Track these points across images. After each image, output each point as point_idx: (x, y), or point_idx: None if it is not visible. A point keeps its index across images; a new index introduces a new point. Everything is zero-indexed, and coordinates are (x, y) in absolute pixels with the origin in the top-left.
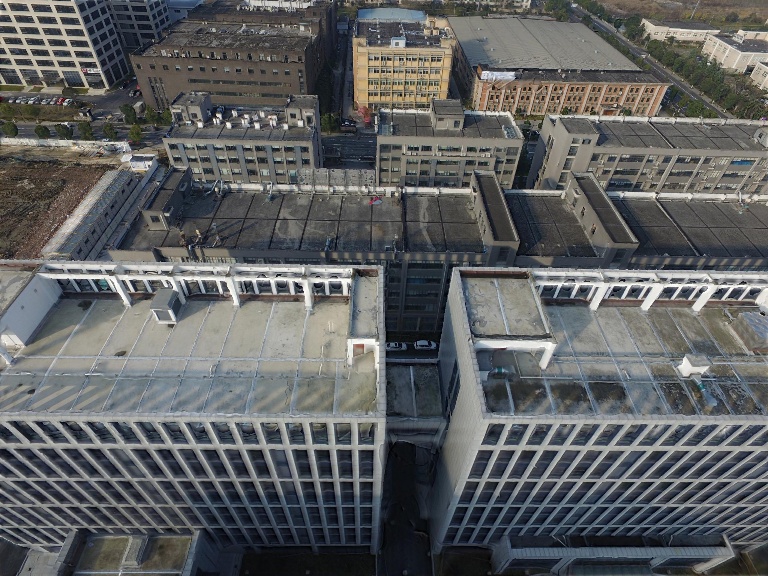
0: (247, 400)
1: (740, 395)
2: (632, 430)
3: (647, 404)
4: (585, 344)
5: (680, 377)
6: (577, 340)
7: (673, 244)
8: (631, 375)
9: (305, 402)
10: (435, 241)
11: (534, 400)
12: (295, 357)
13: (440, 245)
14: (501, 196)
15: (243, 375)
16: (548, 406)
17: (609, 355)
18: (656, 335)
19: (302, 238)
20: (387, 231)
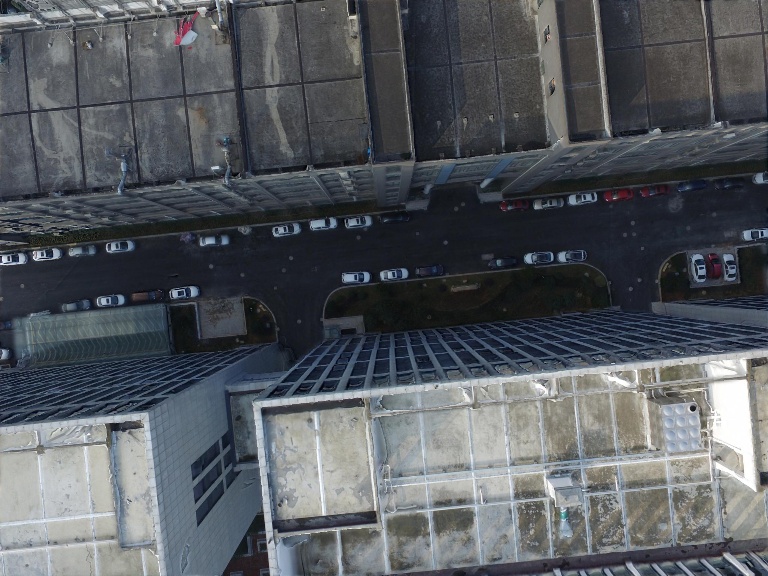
0: (48, 575)
1: (609, 509)
2: (468, 566)
3: (494, 533)
4: (443, 453)
5: (547, 493)
6: (434, 447)
7: (683, 90)
8: (488, 495)
9: (111, 571)
10: (292, 134)
11: (366, 542)
12: (86, 513)
13: (300, 143)
14: (398, 24)
15: (33, 543)
16: (380, 548)
17: (469, 467)
18: (541, 427)
19: (82, 155)
20: (213, 119)
